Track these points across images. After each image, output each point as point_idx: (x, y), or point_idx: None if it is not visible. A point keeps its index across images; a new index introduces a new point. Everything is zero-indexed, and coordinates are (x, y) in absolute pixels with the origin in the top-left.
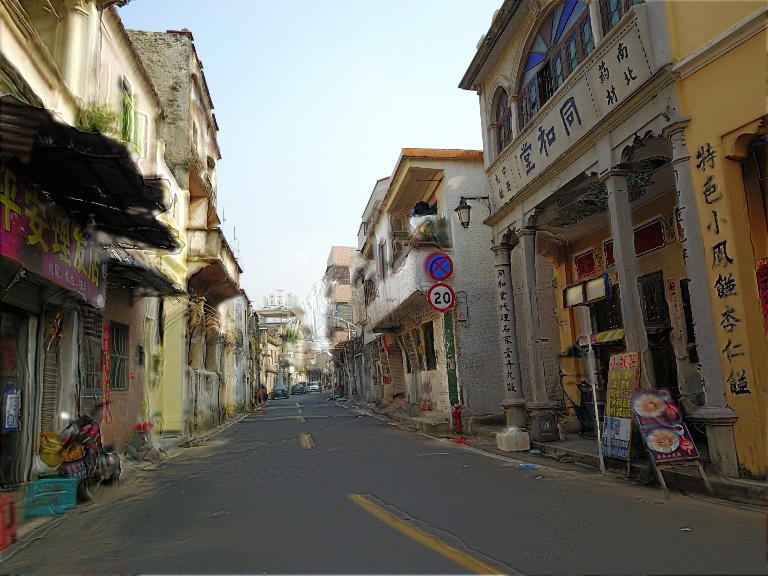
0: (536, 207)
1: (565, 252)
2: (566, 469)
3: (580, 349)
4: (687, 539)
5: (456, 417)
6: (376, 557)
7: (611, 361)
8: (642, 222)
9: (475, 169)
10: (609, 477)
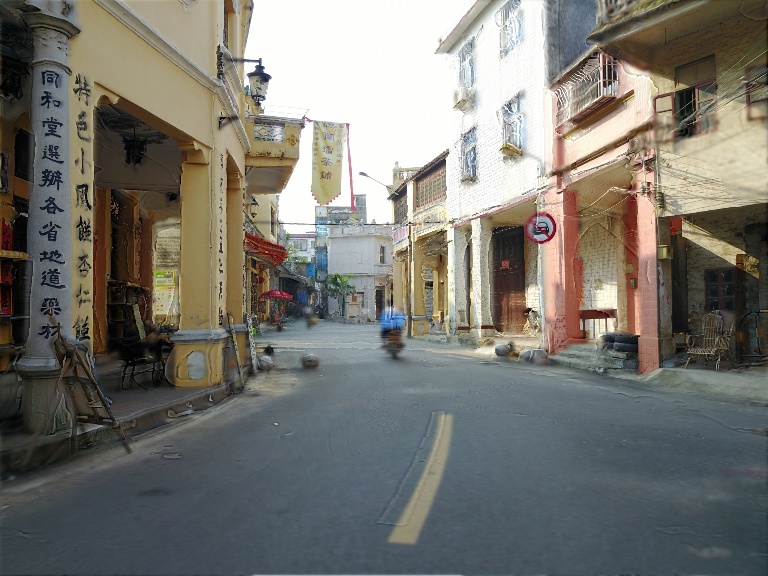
0: None
1: None
2: None
3: None
4: (298, 422)
5: None
6: (497, 442)
7: None
8: None
9: None
10: None
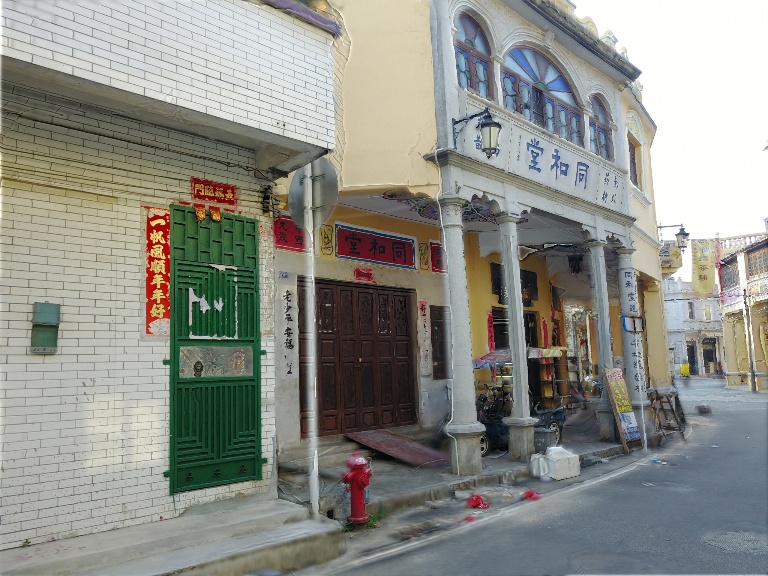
0: (531, 208)
1: None
2: (640, 457)
3: None
4: None
5: None
6: None
7: (608, 374)
8: (393, 232)
9: None
10: (649, 451)
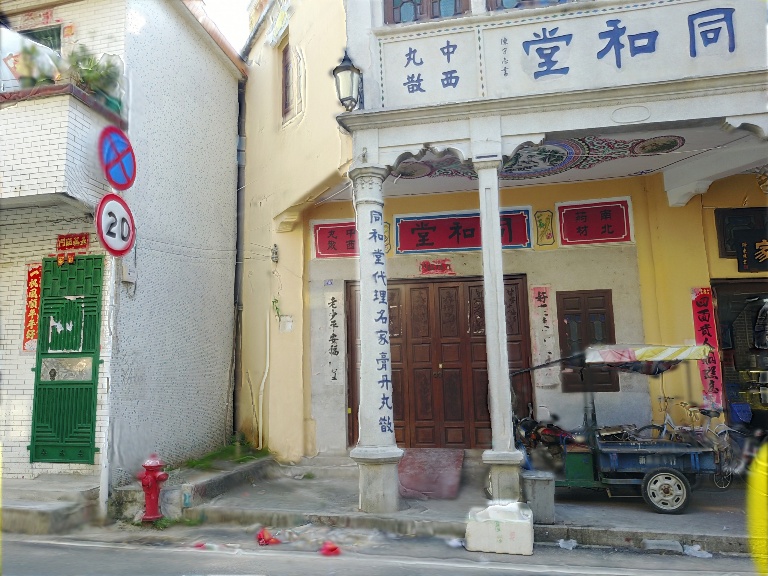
0: (547, 133)
1: (303, 213)
2: None
3: (308, 361)
4: None
5: (150, 488)
6: None
7: None
8: None
9: (163, 15)
10: None
